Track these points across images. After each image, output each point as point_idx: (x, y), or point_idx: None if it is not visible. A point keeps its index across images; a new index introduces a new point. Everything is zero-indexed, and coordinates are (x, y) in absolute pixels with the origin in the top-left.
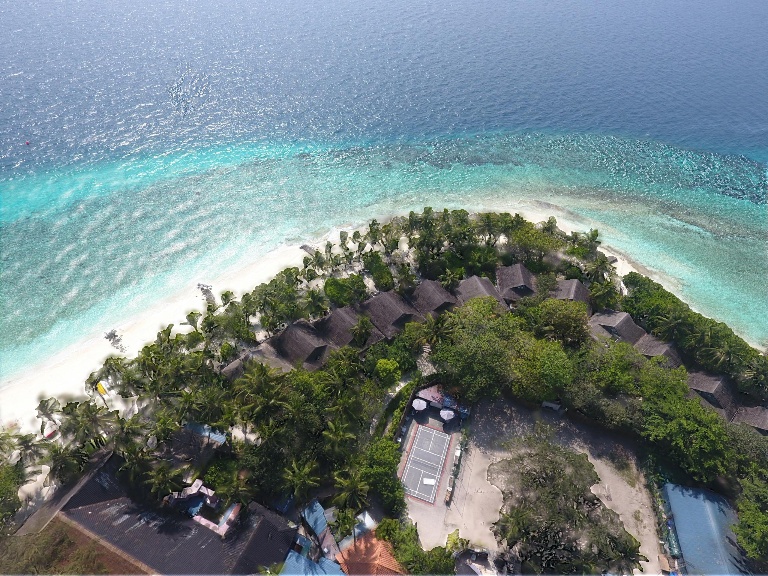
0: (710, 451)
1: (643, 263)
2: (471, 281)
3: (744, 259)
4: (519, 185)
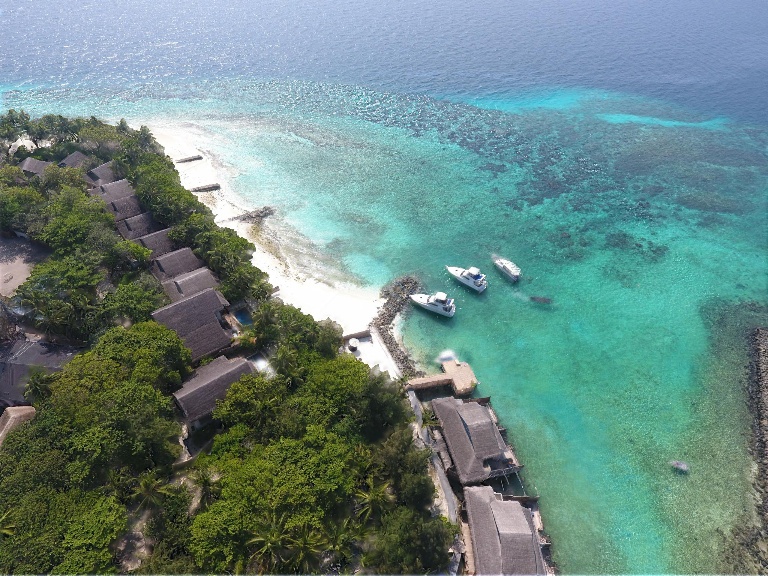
0: (64, 243)
1: (224, 161)
2: (24, 161)
3: (319, 160)
4: (183, 112)
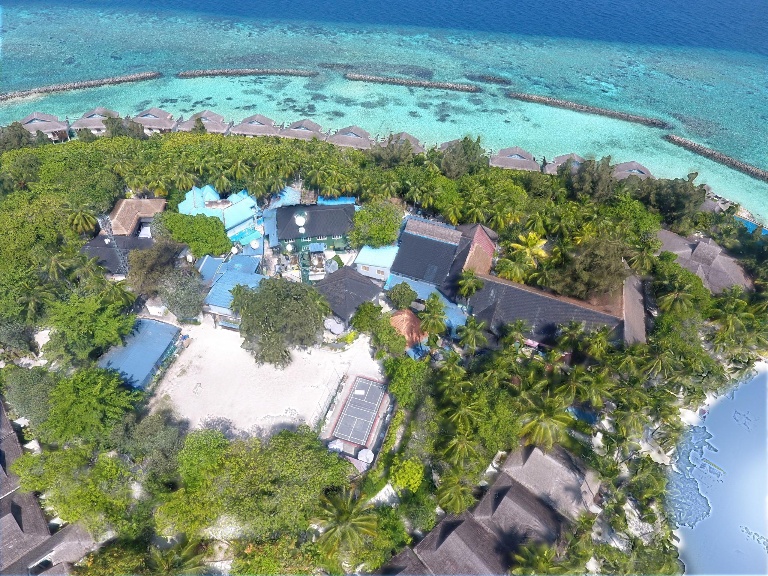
0: None
1: None
2: None
3: None
4: None
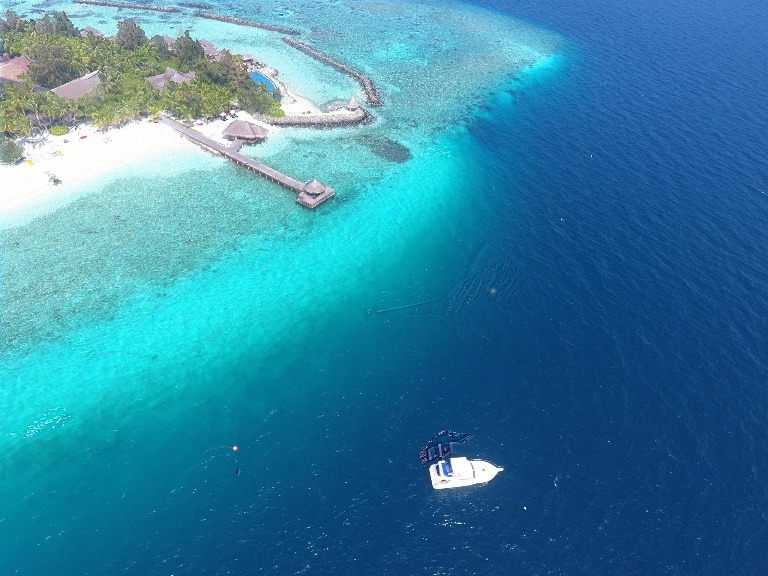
0: None
1: None
2: None
3: None
4: None
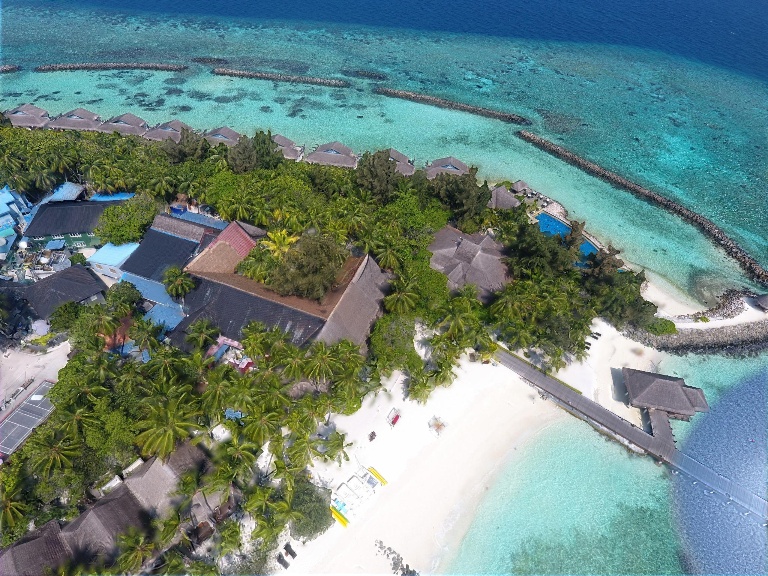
0: None
1: None
2: None
3: None
4: None
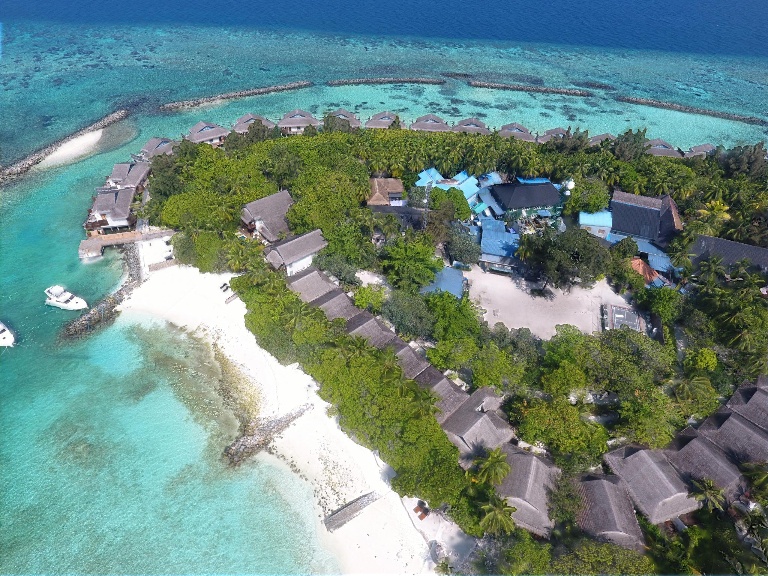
0: None
1: None
2: (676, 485)
3: None
4: None
